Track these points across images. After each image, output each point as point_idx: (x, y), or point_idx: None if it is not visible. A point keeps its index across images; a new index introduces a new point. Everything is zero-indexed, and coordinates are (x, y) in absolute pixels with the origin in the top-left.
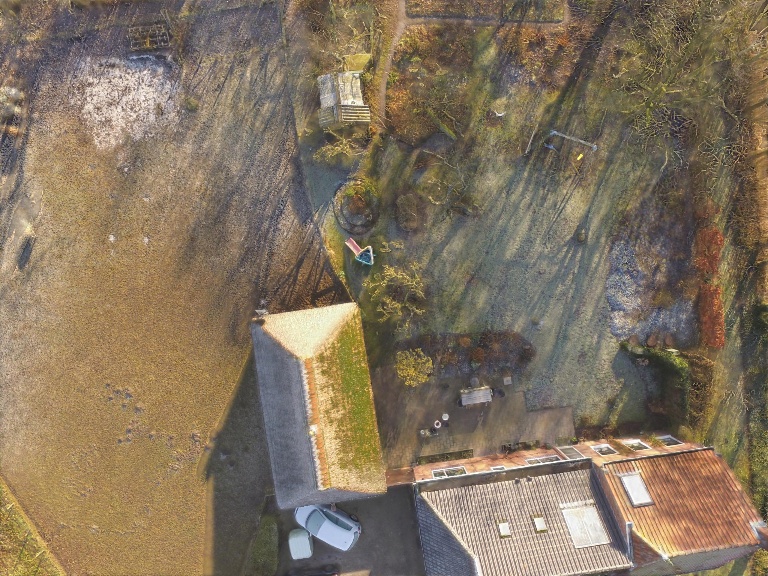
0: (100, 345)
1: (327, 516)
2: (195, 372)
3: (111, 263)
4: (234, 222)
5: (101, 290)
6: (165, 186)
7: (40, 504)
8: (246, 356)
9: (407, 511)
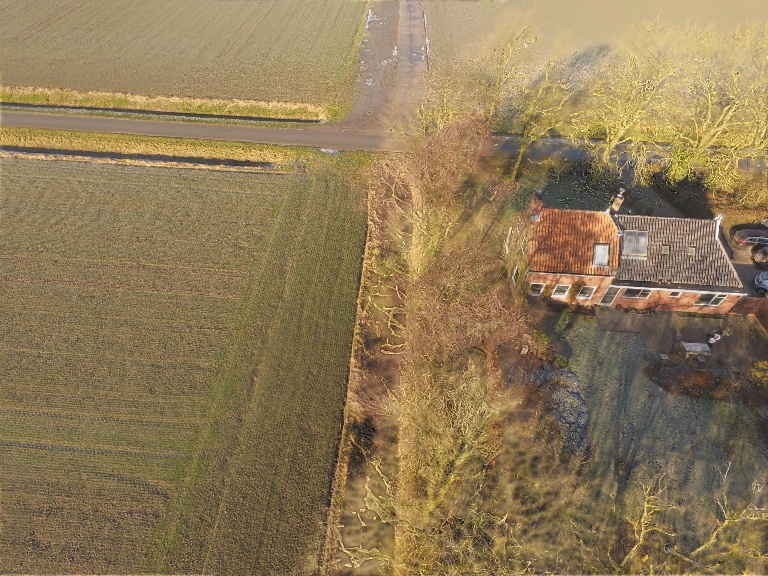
0: None
1: None
2: None
3: None
4: None
5: None
6: None
7: None
8: None
9: None
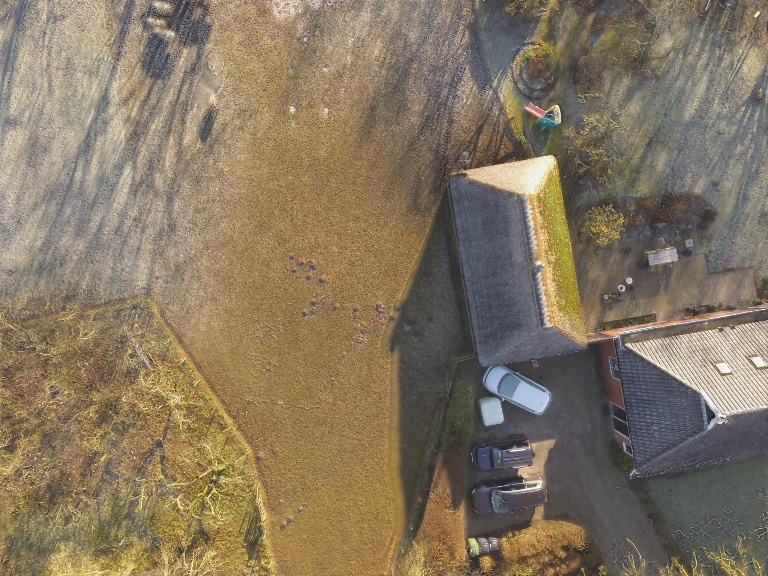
0: (283, 218)
1: (521, 378)
2: (378, 243)
3: (292, 135)
4: (414, 90)
5: (283, 162)
6: (345, 55)
7: (226, 380)
8: (428, 225)
9: (591, 378)
